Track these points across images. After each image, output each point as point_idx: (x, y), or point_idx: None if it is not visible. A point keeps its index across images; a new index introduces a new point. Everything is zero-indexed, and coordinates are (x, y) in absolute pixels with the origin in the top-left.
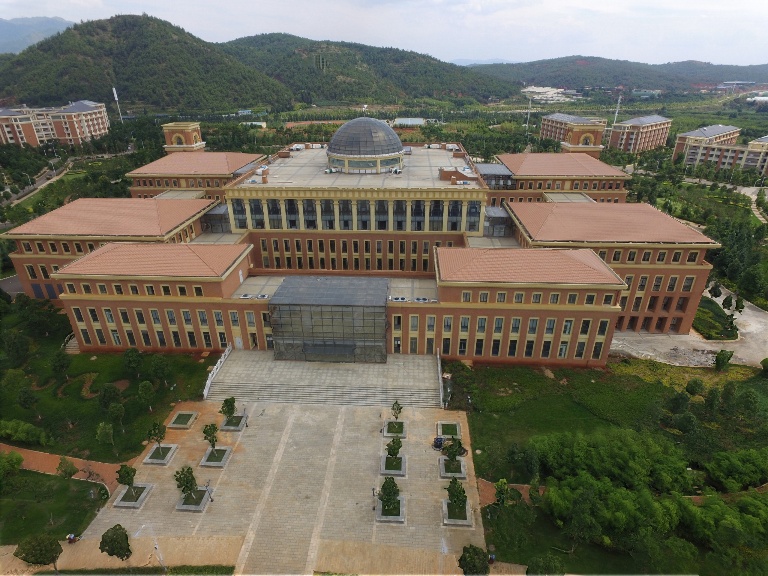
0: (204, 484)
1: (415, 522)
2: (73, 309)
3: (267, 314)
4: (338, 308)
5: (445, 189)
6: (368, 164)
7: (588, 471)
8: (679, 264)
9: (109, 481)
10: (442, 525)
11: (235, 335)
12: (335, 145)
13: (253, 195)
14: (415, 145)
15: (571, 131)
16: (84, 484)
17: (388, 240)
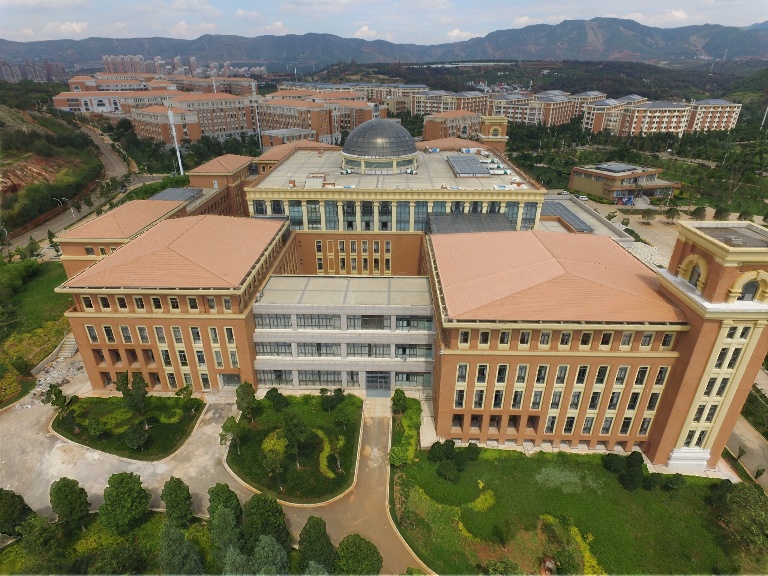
0: None
1: None
2: None
3: None
4: None
5: None
6: None
7: None
8: None
9: None
10: None
11: None
12: None
13: None
14: (524, 177)
15: None
16: None
17: None
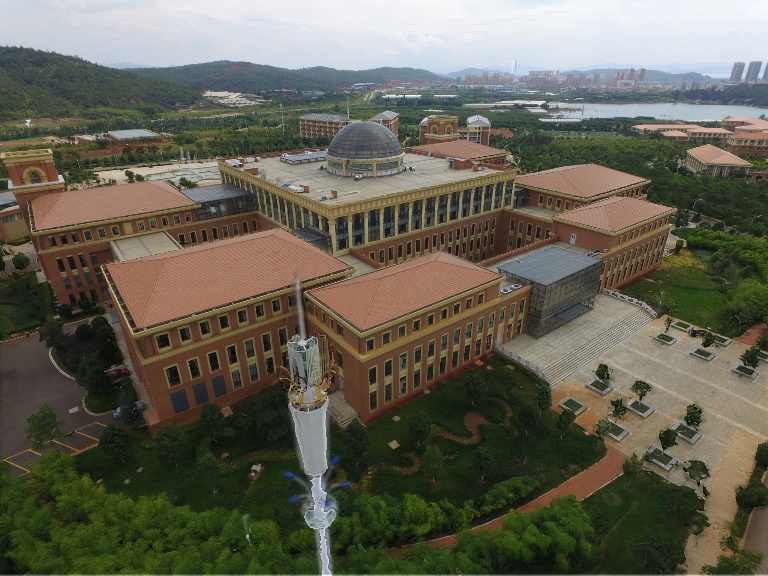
0: (669, 424)
1: (760, 370)
2: (369, 371)
3: (522, 301)
4: (581, 272)
5: (495, 174)
6: (352, 168)
7: (765, 307)
8: (635, 197)
9: None
10: (767, 364)
11: (498, 332)
12: (356, 150)
13: (357, 209)
14: None
15: (436, 124)
16: (623, 479)
17: (457, 228)
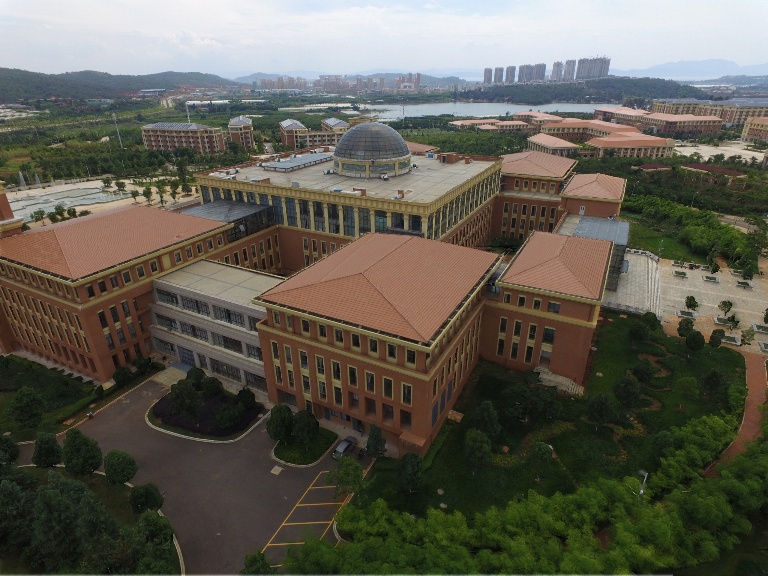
0: (749, 327)
1: None
2: None
3: None
4: None
5: None
6: None
7: None
8: None
9: (762, 358)
10: None
11: None
12: (379, 151)
13: (438, 205)
14: (298, 153)
15: None
16: None
17: None
